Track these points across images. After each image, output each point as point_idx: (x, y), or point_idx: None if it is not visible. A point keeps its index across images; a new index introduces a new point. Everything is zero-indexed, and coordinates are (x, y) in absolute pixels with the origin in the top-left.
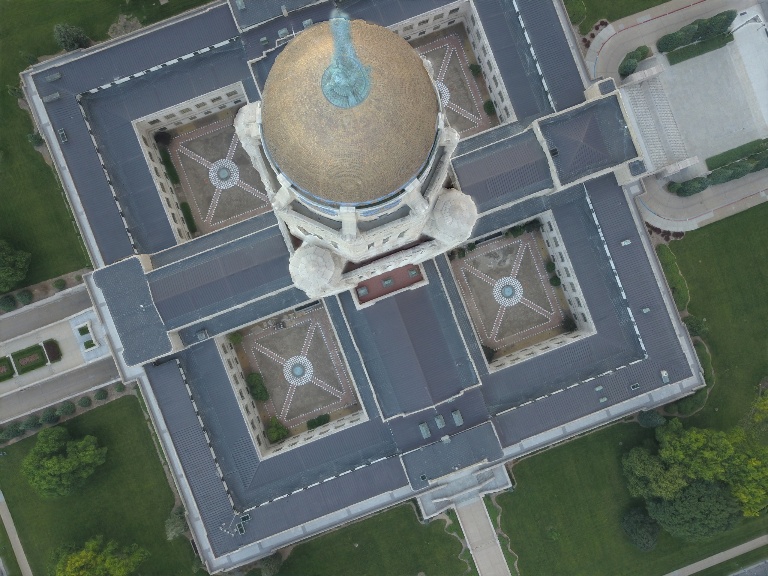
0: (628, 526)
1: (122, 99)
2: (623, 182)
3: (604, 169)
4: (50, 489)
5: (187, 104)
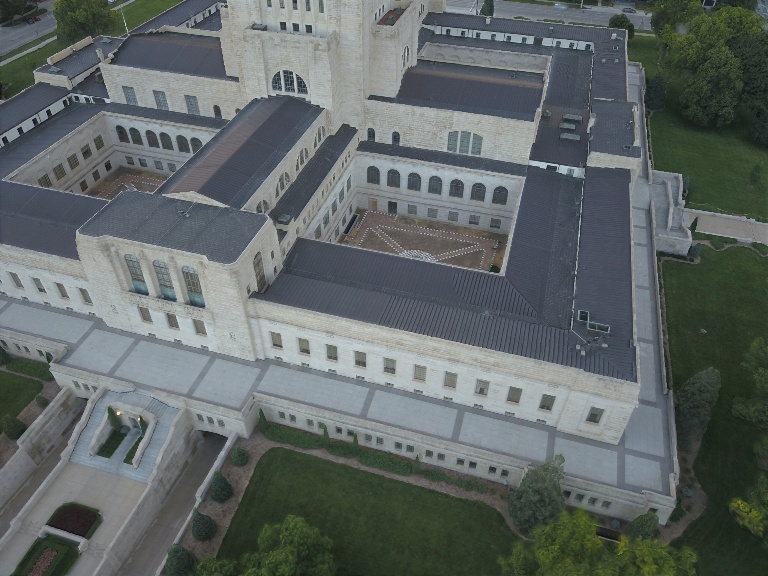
0: (766, 133)
1: None
2: (441, 3)
3: None
4: None
5: (59, 145)
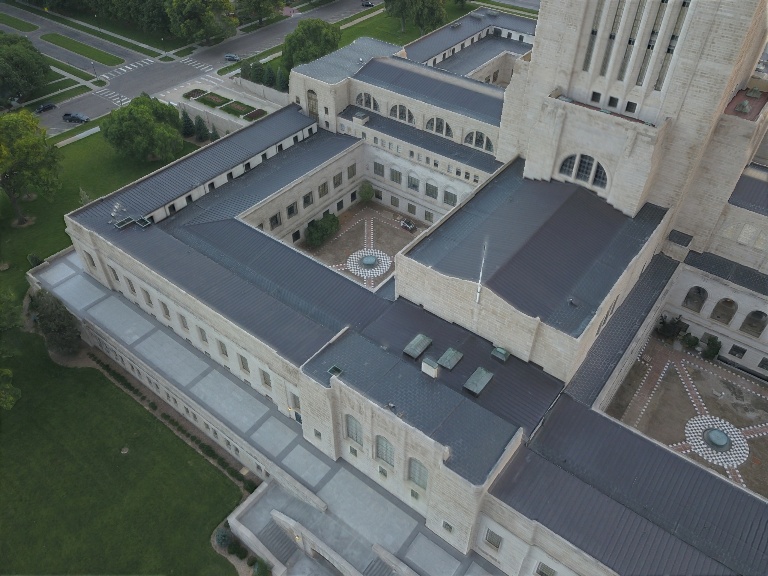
0: None
1: None
2: None
3: None
4: (112, 120)
5: None
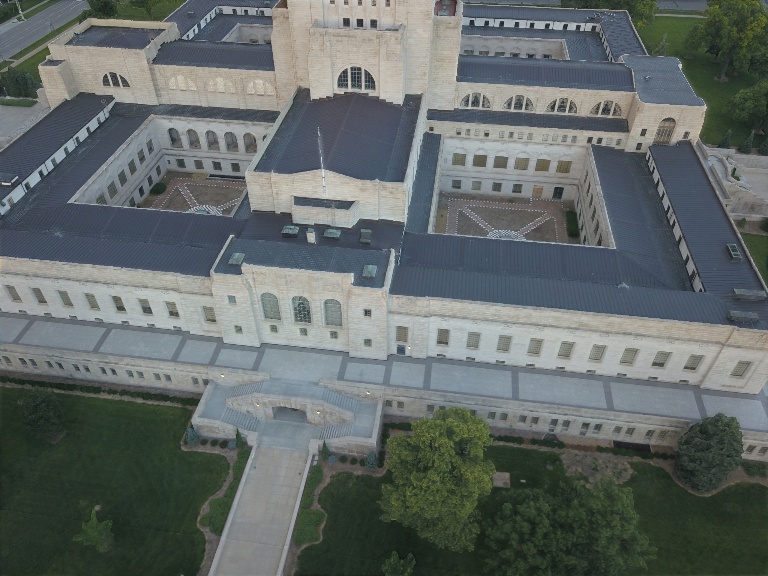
0: None
1: (624, 282)
2: None
3: (128, 21)
4: None
5: None
